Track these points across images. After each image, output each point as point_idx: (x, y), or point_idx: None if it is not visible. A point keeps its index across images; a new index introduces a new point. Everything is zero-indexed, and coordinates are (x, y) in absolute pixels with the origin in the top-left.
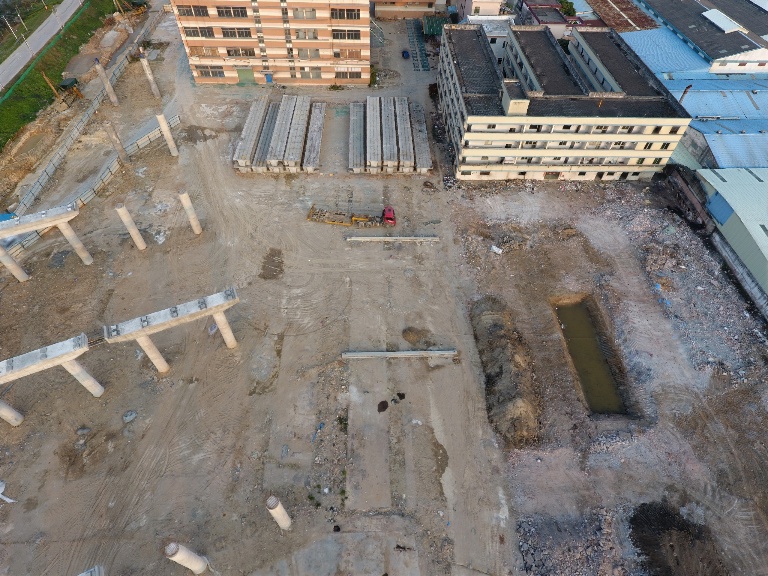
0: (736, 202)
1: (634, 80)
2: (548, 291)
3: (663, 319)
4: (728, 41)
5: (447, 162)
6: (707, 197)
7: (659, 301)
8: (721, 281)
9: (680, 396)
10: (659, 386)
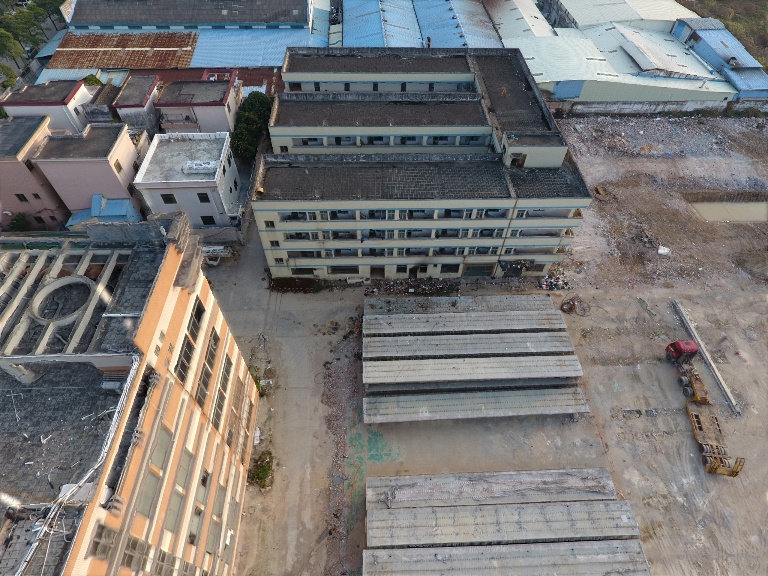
0: (575, 76)
1: (430, 64)
2: (698, 221)
3: (688, 160)
4: (278, 2)
5: (507, 283)
6: (552, 92)
7: (670, 157)
8: (623, 121)
9: (762, 169)
10: (761, 177)
